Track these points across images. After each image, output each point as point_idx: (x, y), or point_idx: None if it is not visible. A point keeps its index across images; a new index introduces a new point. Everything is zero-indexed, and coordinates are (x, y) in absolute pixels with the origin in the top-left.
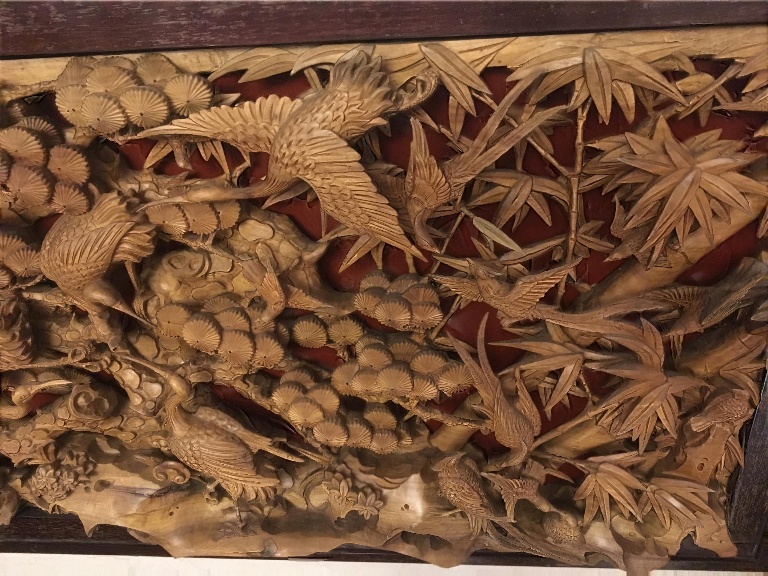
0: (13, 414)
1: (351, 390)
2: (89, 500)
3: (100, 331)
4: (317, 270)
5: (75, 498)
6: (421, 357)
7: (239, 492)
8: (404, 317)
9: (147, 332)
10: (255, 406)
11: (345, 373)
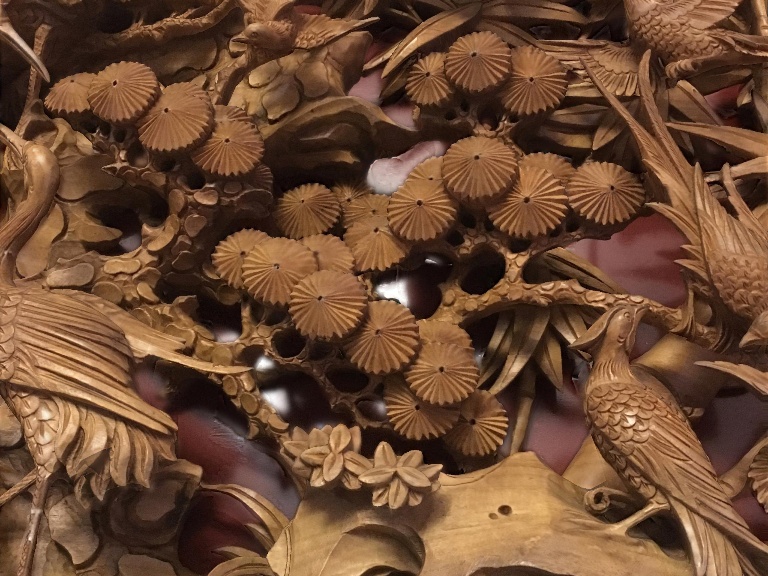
0: None
1: (382, 248)
2: None
3: None
4: None
5: None
6: (530, 156)
7: (65, 436)
8: (500, 54)
9: None
10: (158, 364)
11: (373, 221)
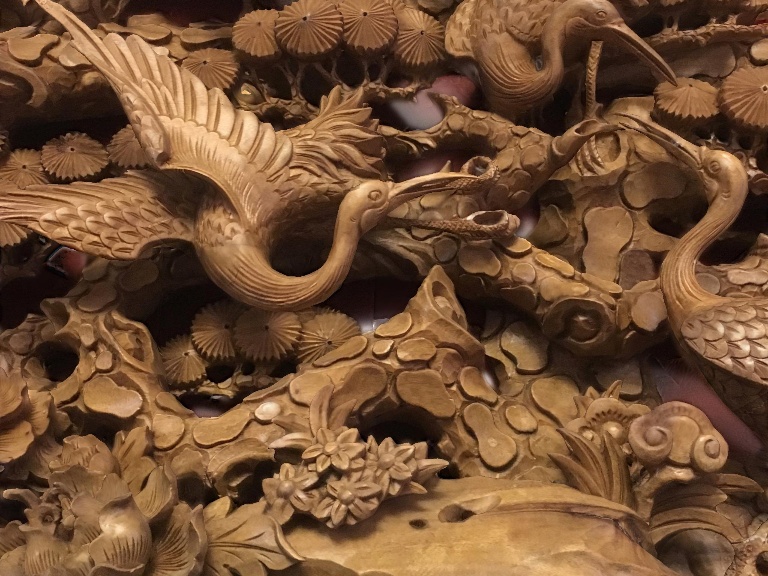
0: (300, 285)
1: None
2: (429, 541)
3: (533, 132)
4: None
5: (383, 542)
6: None
7: None
8: None
9: (551, 252)
10: None
11: None
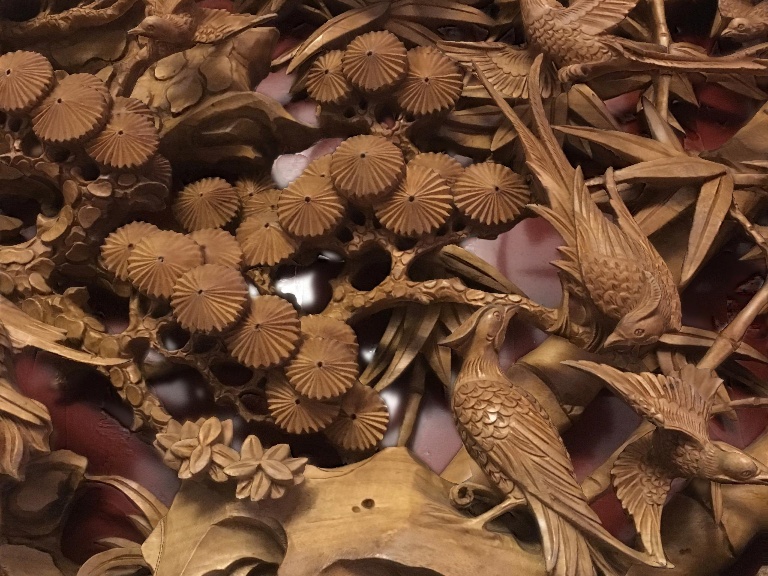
0: None
1: (272, 243)
2: None
3: None
4: (249, 85)
5: None
6: (421, 155)
7: None
8: (395, 54)
9: None
10: (47, 355)
11: (265, 216)
